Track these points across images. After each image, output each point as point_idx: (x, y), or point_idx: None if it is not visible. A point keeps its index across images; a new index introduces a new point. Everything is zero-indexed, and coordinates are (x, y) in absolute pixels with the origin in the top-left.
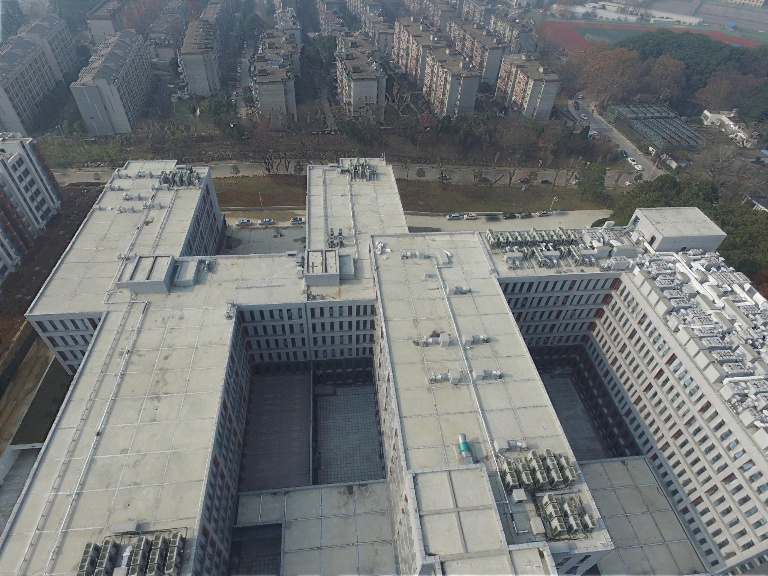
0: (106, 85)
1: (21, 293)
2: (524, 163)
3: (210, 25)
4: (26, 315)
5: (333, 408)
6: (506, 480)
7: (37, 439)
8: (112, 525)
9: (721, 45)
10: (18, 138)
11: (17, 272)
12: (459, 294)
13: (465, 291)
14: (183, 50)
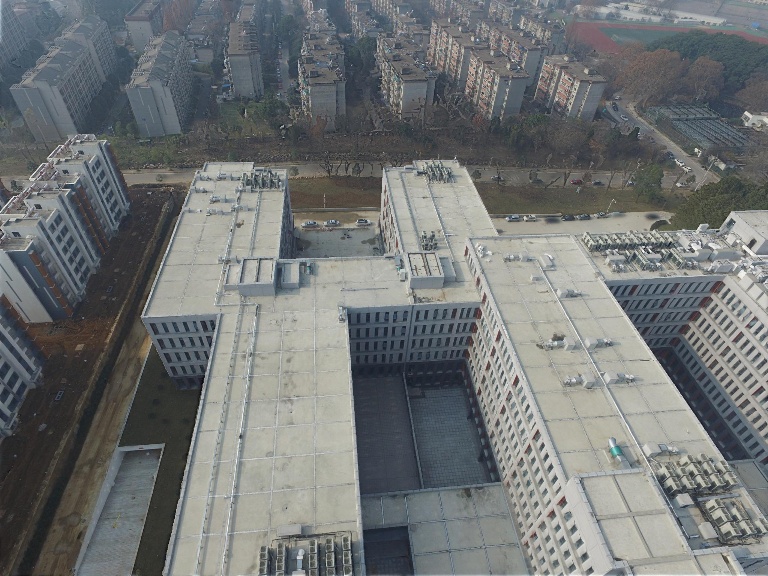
0: (160, 87)
1: (105, 295)
2: (575, 164)
3: (251, 26)
4: (142, 317)
5: (424, 410)
6: (666, 484)
7: (144, 441)
8: (276, 528)
9: (759, 46)
10: (95, 140)
11: (98, 274)
12: (570, 297)
13: (576, 294)
14: (230, 51)
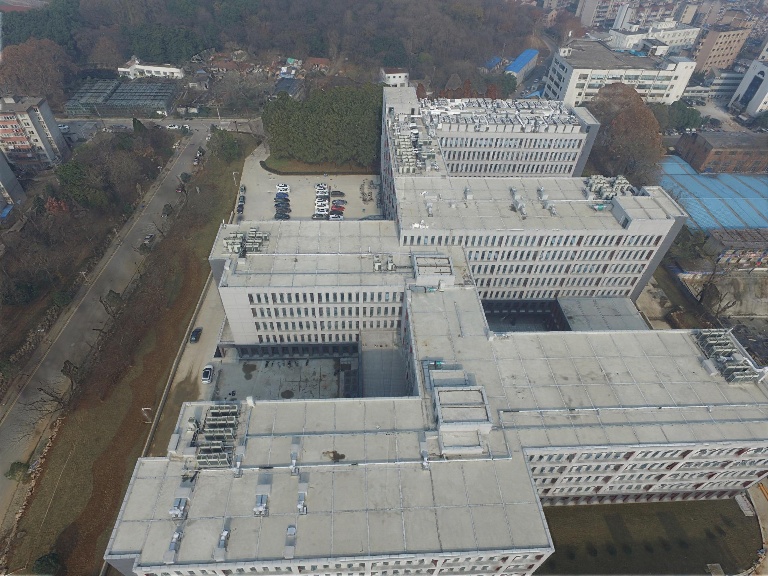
0: None
1: None
2: None
3: None
4: None
5: None
6: None
7: None
8: None
9: (43, 12)
10: None
11: None
12: None
13: None
14: None
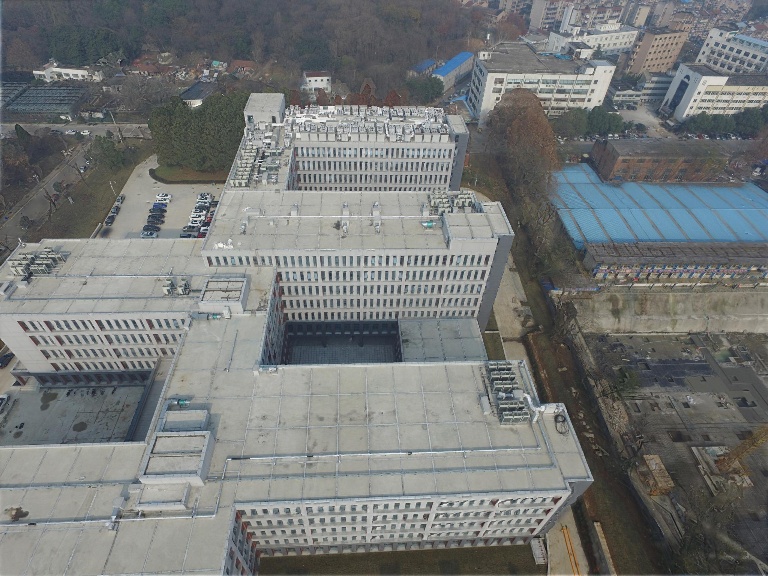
0: None
1: None
2: None
3: None
4: None
5: None
6: None
7: None
8: None
9: None
10: None
11: None
12: (297, 211)
13: None
14: None
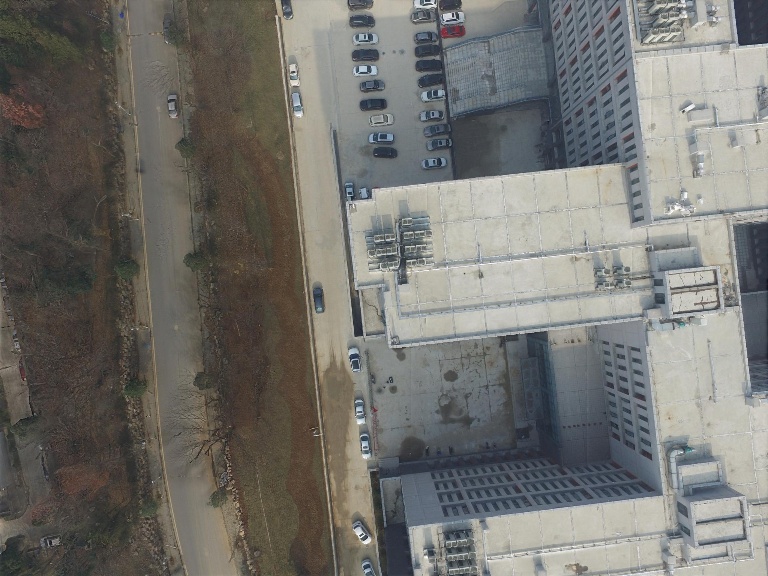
0: None
1: None
2: None
3: None
4: None
5: None
6: None
7: None
8: None
9: None
10: None
11: None
12: None
13: (766, 94)
14: None
